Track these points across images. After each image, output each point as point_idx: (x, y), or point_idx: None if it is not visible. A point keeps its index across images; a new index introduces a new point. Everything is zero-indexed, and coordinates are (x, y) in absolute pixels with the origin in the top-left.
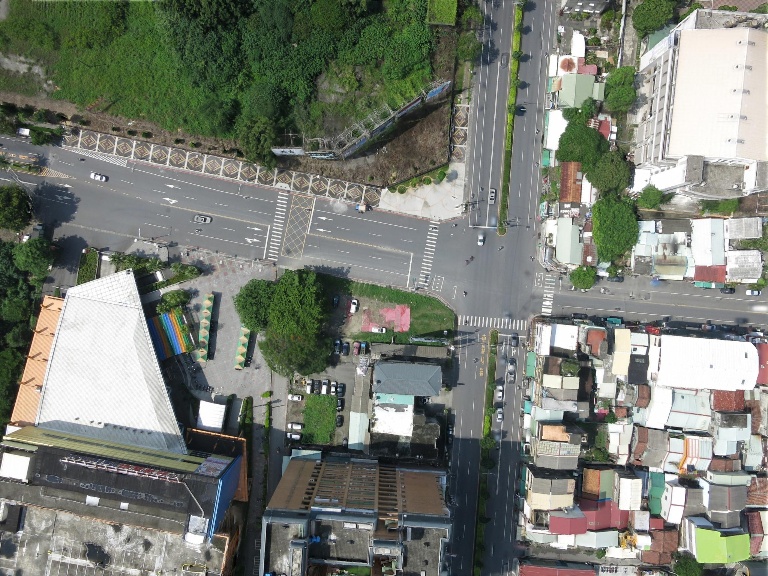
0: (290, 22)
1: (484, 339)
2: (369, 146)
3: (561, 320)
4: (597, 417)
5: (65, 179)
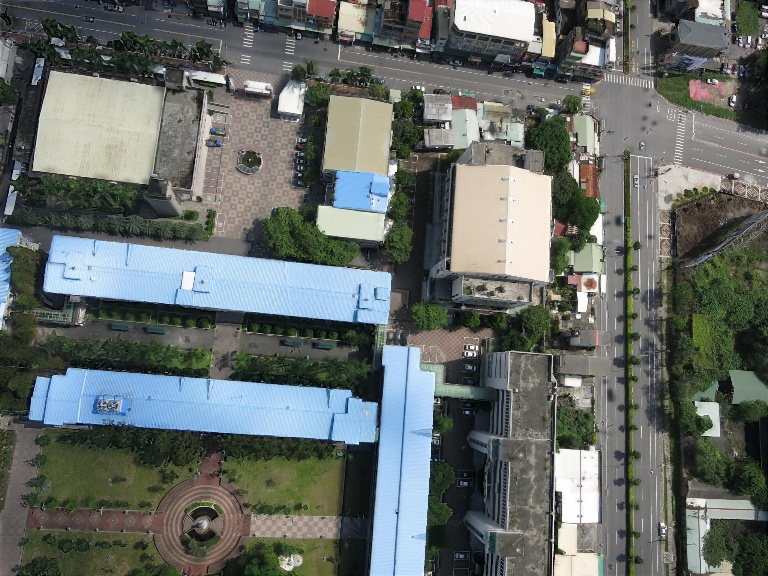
0: None
1: (634, 69)
2: (733, 226)
3: (581, 75)
4: (542, 0)
5: None
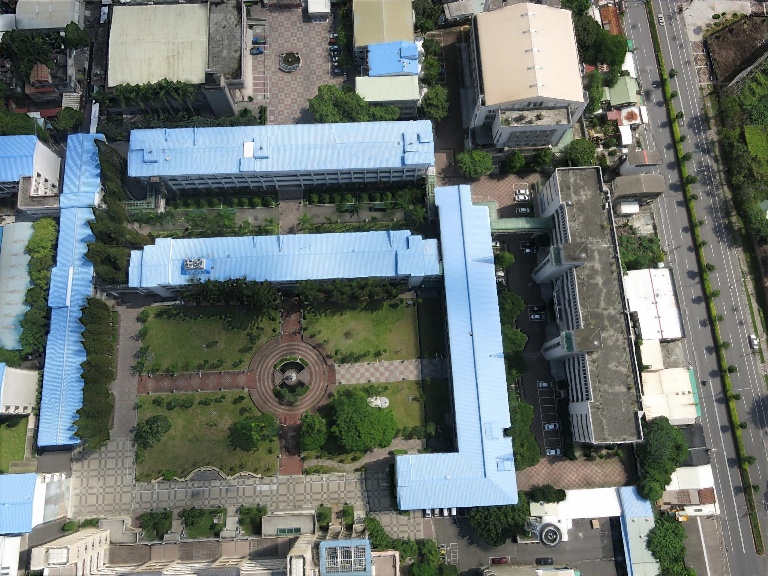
0: None
1: None
2: None
3: None
4: None
5: None
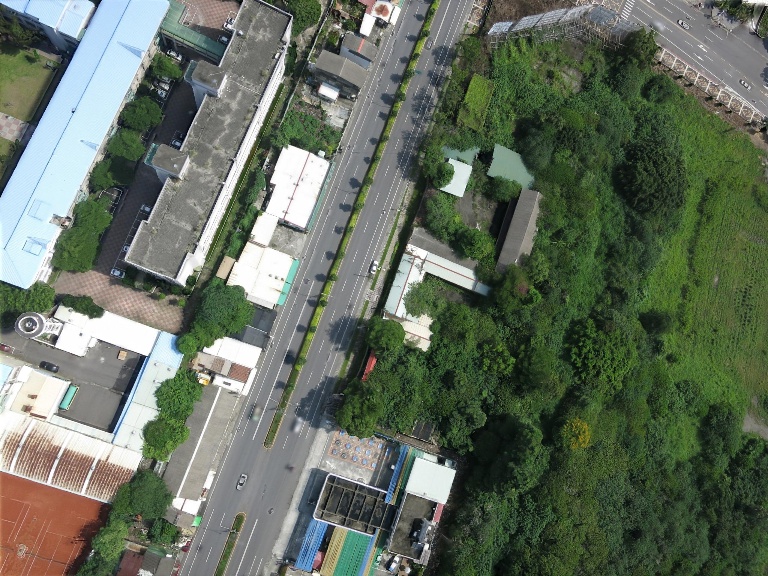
0: (602, 123)
1: None
2: None
3: None
4: None
5: (767, 93)
